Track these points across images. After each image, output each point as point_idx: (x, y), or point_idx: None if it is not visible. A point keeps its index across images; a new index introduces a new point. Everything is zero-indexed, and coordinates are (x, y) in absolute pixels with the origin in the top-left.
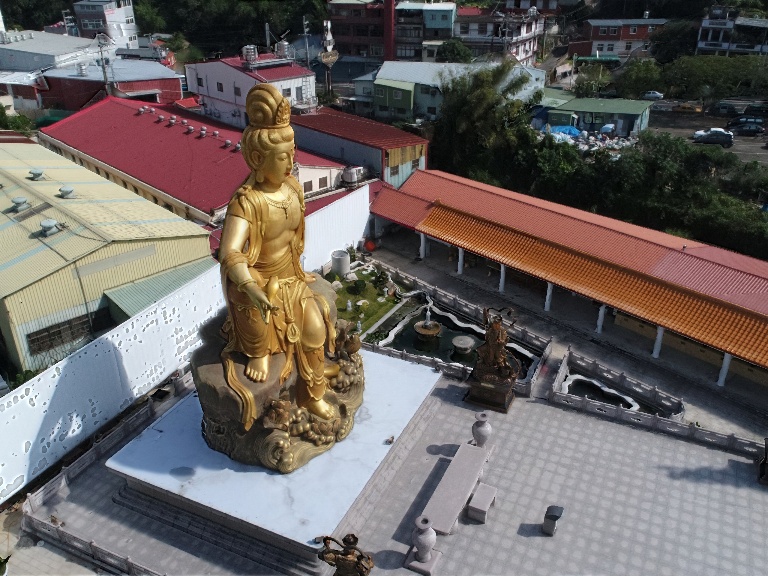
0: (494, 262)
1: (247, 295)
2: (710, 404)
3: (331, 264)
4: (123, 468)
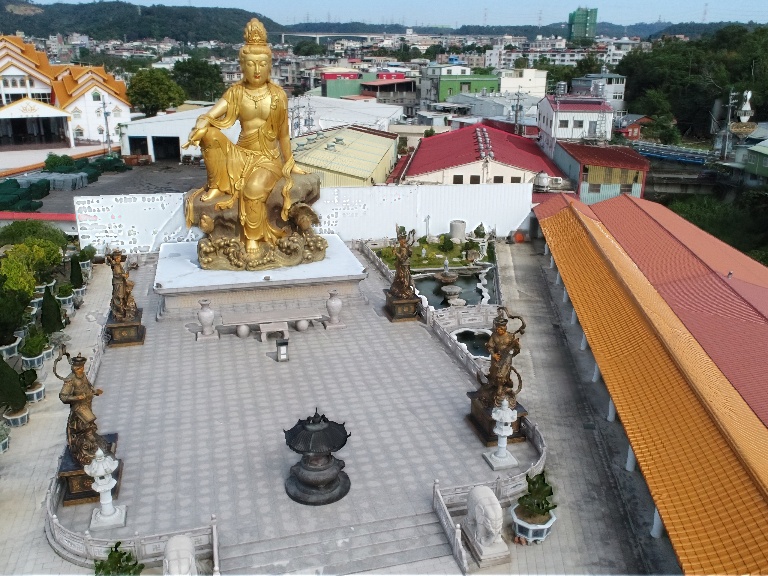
0: None
1: None
2: (552, 382)
3: (465, 236)
4: (163, 246)
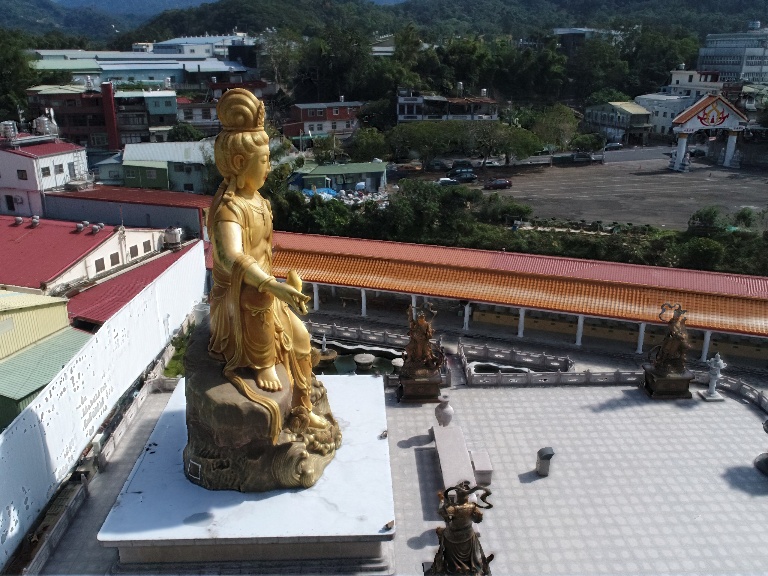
0: (341, 295)
1: (264, 296)
2: (582, 359)
3: (186, 323)
4: (124, 536)
